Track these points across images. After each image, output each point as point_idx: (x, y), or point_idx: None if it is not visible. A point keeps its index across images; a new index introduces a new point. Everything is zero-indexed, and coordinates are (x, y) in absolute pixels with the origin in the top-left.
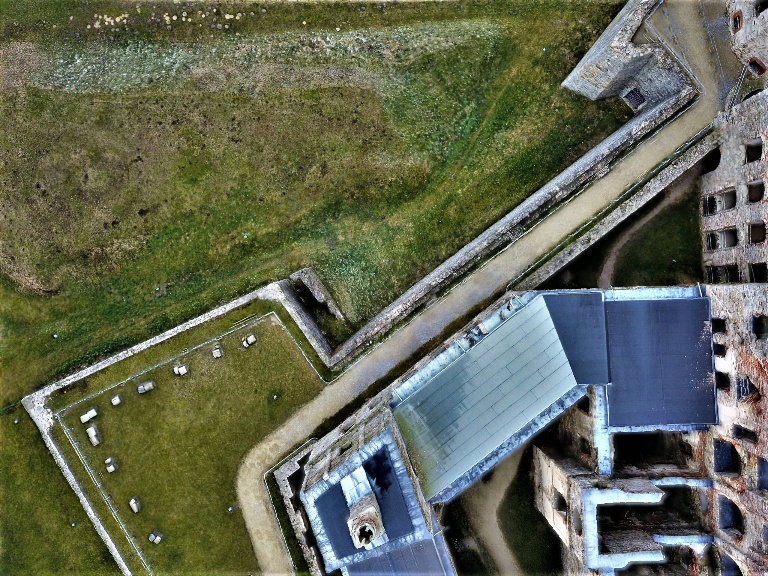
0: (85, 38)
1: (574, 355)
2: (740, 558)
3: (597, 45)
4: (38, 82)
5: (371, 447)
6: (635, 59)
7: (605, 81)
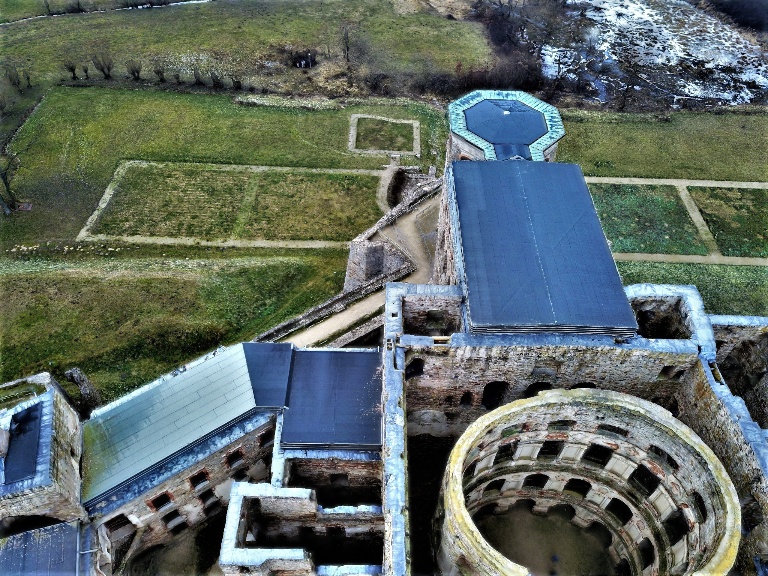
0: (0, 256)
1: (258, 384)
2: None
3: None
4: None
5: (28, 403)
6: (371, 250)
7: (362, 274)
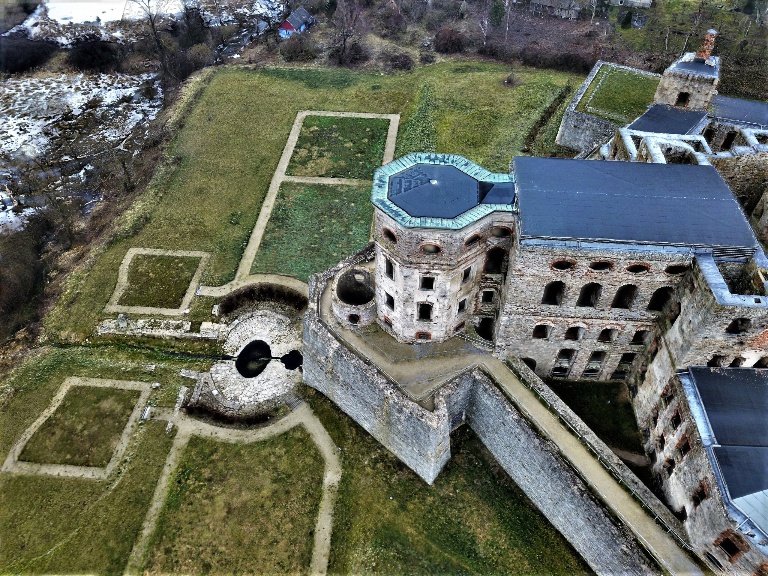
0: None
1: None
2: None
3: (407, 446)
4: None
5: None
6: None
7: (447, 441)
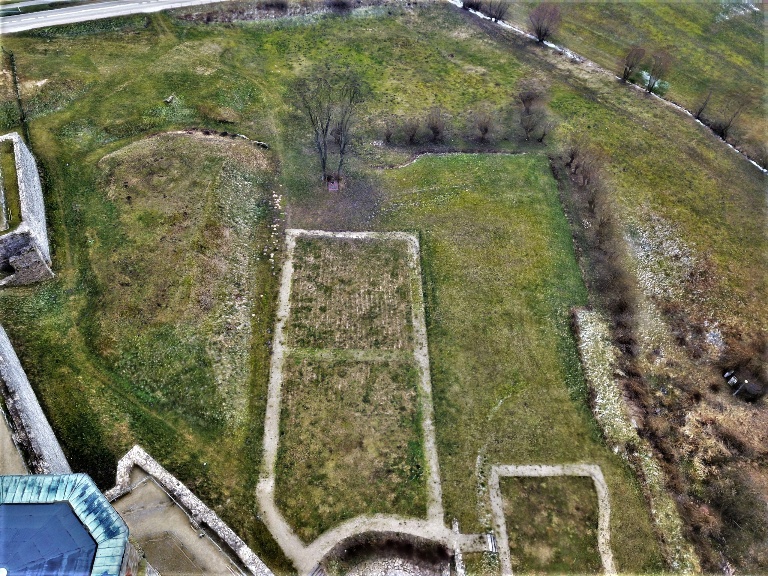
0: (266, 190)
1: None
2: None
3: None
4: (229, 161)
5: None
6: None
7: None
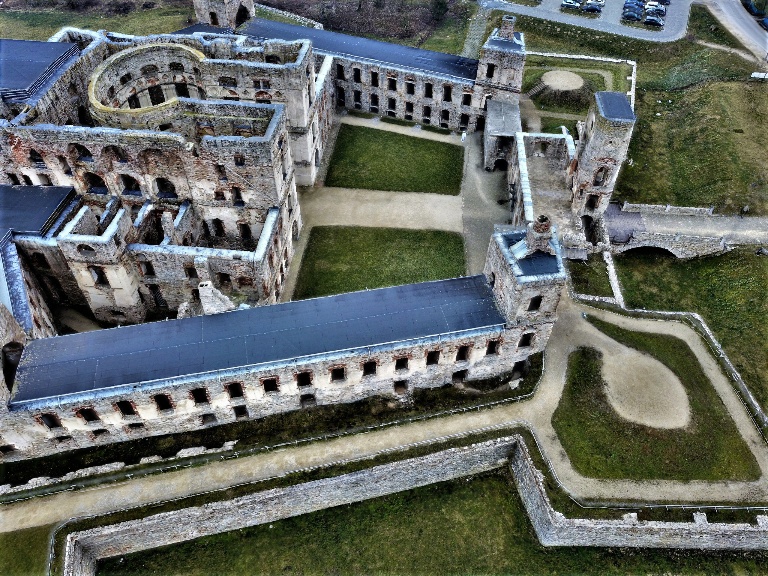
0: None
1: None
2: (141, 178)
3: None
4: None
5: None
6: None
7: None
